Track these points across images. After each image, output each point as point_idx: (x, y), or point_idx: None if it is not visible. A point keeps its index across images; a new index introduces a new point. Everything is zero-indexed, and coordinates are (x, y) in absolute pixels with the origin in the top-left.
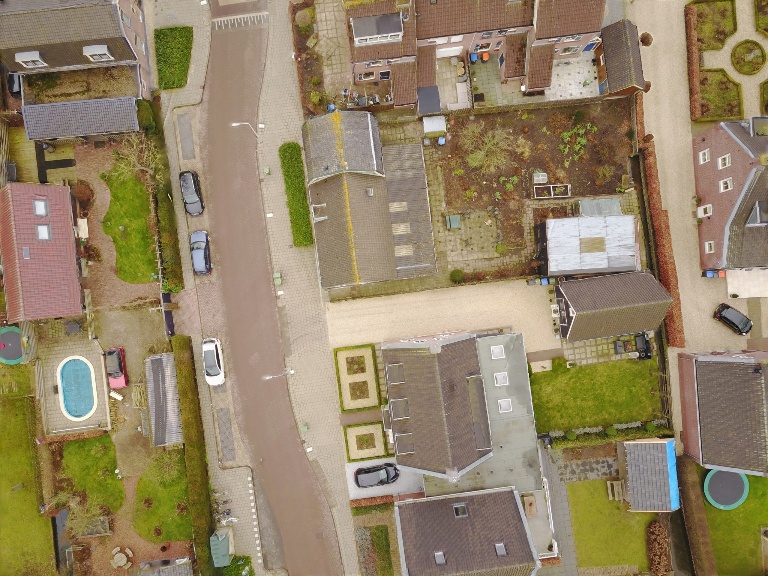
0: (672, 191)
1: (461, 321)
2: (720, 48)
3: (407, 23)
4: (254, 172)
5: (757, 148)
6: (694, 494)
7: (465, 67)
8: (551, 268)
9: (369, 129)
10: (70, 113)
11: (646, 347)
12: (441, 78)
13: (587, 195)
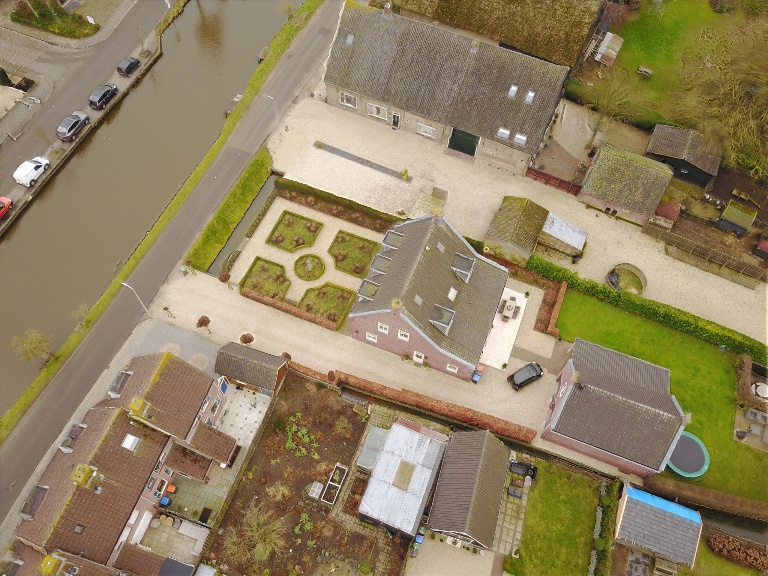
0: (388, 374)
1: None
2: (289, 284)
3: (81, 571)
4: None
5: (384, 302)
6: (687, 491)
7: (168, 515)
8: (409, 529)
9: None
10: None
11: (524, 466)
12: (163, 545)
13: (355, 451)
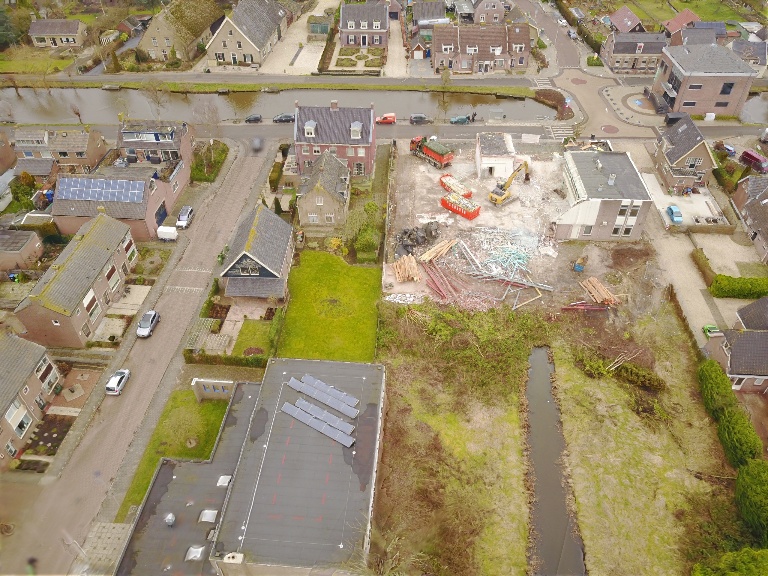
0: None
1: None
2: None
3: None
4: None
5: (383, 14)
6: None
7: None
8: None
9: None
10: None
11: None
12: None
13: None
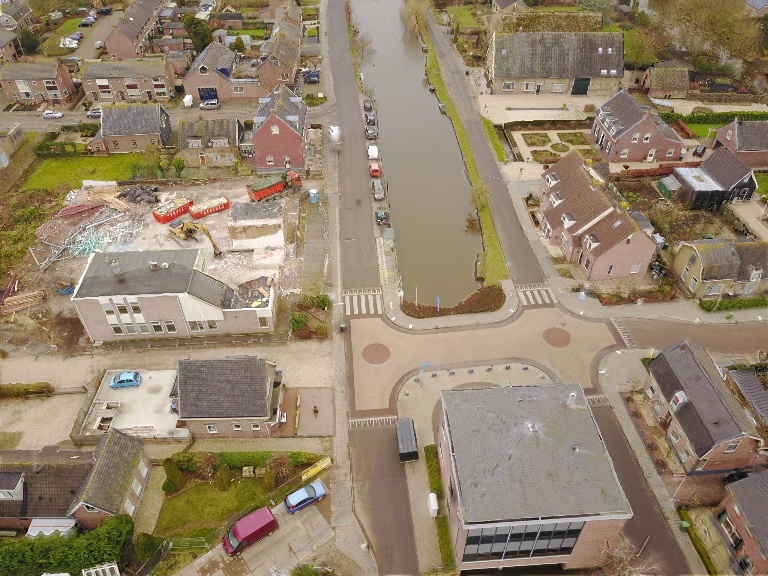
0: None
1: (767, 238)
2: None
3: None
4: (733, 326)
5: (634, 122)
6: None
7: None
8: None
9: (693, 241)
10: (767, 414)
11: None
12: None
13: (659, 194)
